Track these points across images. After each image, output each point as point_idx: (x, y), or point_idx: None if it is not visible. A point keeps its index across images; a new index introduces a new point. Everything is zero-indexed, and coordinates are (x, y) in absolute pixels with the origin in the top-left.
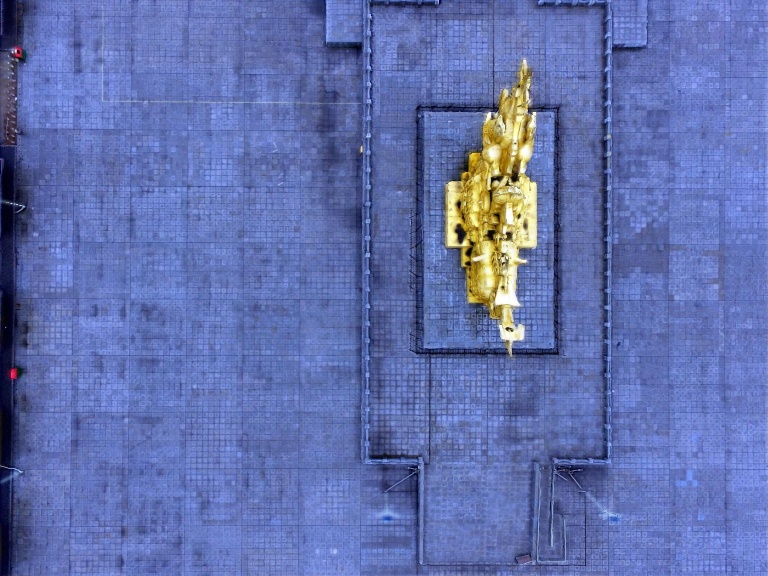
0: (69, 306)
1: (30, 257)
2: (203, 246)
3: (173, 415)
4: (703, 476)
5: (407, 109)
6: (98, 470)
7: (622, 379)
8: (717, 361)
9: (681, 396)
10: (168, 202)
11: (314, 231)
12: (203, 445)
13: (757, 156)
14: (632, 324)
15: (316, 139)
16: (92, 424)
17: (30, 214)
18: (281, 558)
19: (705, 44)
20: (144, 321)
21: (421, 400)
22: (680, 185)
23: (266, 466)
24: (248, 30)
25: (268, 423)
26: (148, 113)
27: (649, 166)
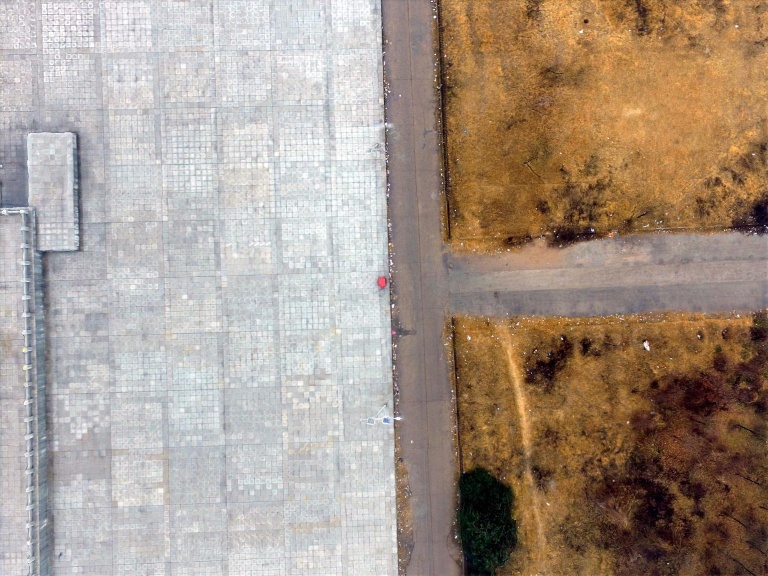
0: None
1: None
2: None
3: None
4: None
5: None
6: None
7: None
8: (163, 567)
9: None
10: None
11: None
12: None
13: (199, 357)
14: (74, 533)
15: None
16: None
17: None
18: None
19: (143, 245)
20: None
21: None
22: (121, 389)
23: None
24: None
25: None
26: None
27: (89, 371)
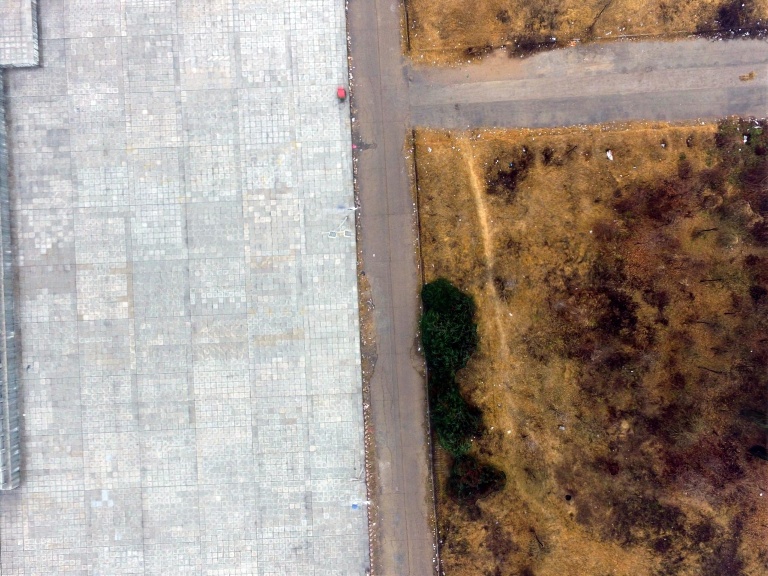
0: None
1: None
2: None
3: None
4: (118, 496)
5: None
6: None
7: (33, 402)
8: (129, 380)
9: (94, 417)
10: None
11: None
12: None
13: (160, 171)
14: (41, 346)
15: None
16: None
17: None
18: None
19: (102, 61)
20: None
21: None
22: (84, 204)
23: None
24: None
25: None
26: None
27: (51, 186)
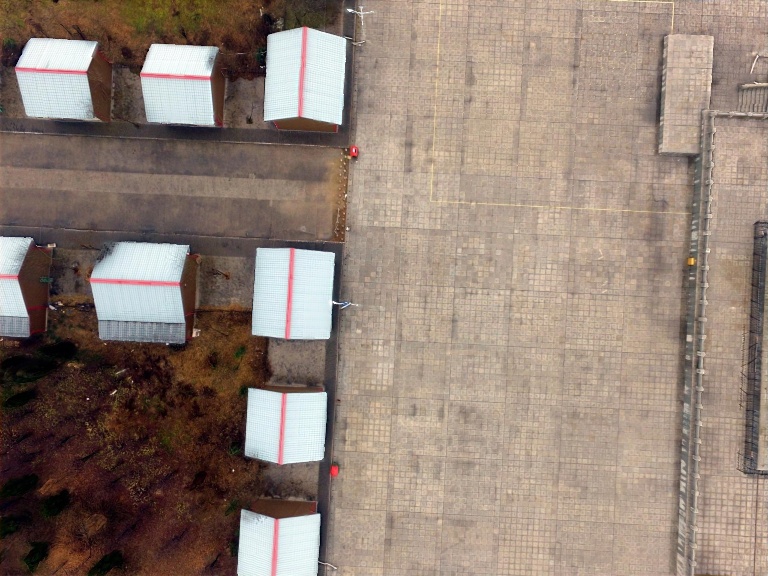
0: (388, 404)
1: (352, 353)
2: (524, 350)
3: (487, 519)
4: None
5: (745, 224)
6: (410, 570)
7: None
8: None
9: None
10: (491, 305)
11: (637, 341)
12: (516, 551)
13: None
14: None
15: (643, 248)
16: (406, 523)
17: (354, 310)
18: None
19: None
20: (462, 423)
21: (747, 521)
22: None
23: None
24: (579, 135)
25: (582, 532)
26: (475, 215)
27: None
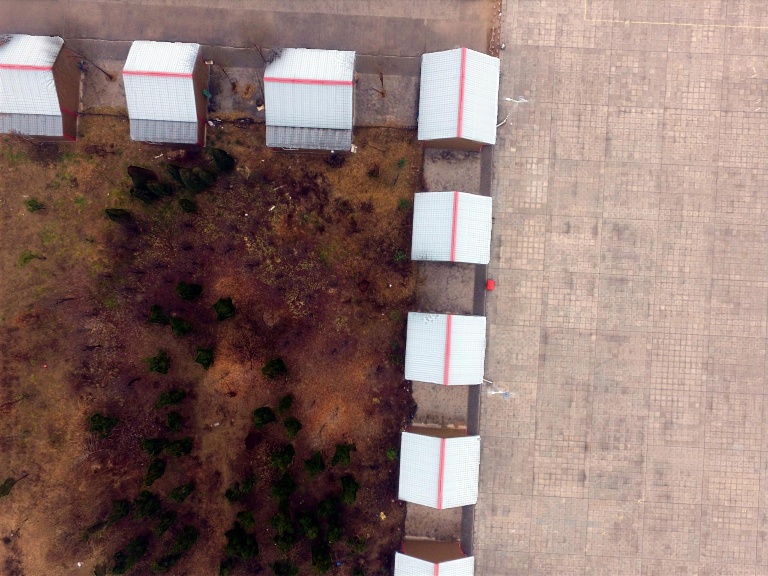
0: (542, 222)
1: (507, 171)
2: (677, 168)
3: (640, 335)
4: None
5: None
6: (564, 385)
7: None
8: None
9: None
10: (645, 123)
11: None
12: (669, 366)
13: None
14: None
15: None
16: (560, 339)
17: (508, 129)
18: (742, 482)
19: None
20: (615, 240)
21: None
22: None
23: (730, 390)
24: None
25: (734, 348)
26: (629, 33)
27: None
